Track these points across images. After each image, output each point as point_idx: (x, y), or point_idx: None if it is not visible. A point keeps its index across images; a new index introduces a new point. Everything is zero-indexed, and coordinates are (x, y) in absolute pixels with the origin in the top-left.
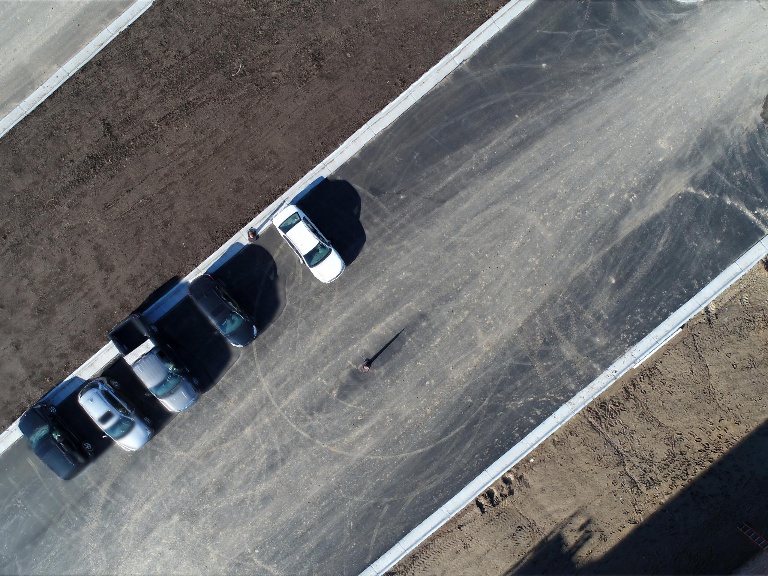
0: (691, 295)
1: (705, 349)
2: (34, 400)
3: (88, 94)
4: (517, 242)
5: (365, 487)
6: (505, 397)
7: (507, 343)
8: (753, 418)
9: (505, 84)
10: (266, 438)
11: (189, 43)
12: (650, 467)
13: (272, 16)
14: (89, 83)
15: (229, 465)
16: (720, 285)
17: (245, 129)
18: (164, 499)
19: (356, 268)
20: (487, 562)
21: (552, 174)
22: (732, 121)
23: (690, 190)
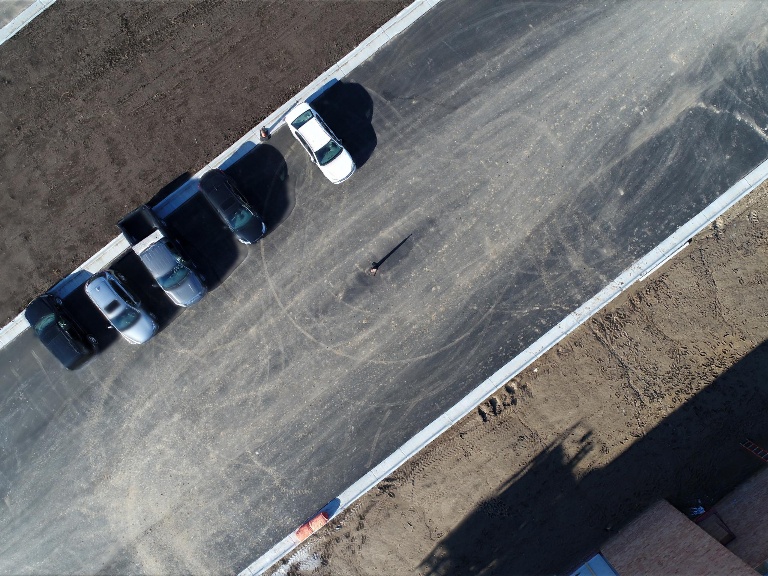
0: (699, 209)
1: (712, 264)
2: (41, 292)
3: None
4: (527, 151)
5: (368, 391)
6: (511, 305)
7: (514, 252)
8: (758, 334)
9: None
10: (270, 339)
11: None
12: (654, 380)
13: None
14: None
15: (233, 365)
16: (728, 200)
17: (261, 29)
18: (166, 397)
19: (366, 171)
20: (488, 471)
21: (564, 84)
22: (744, 38)
23: (701, 105)
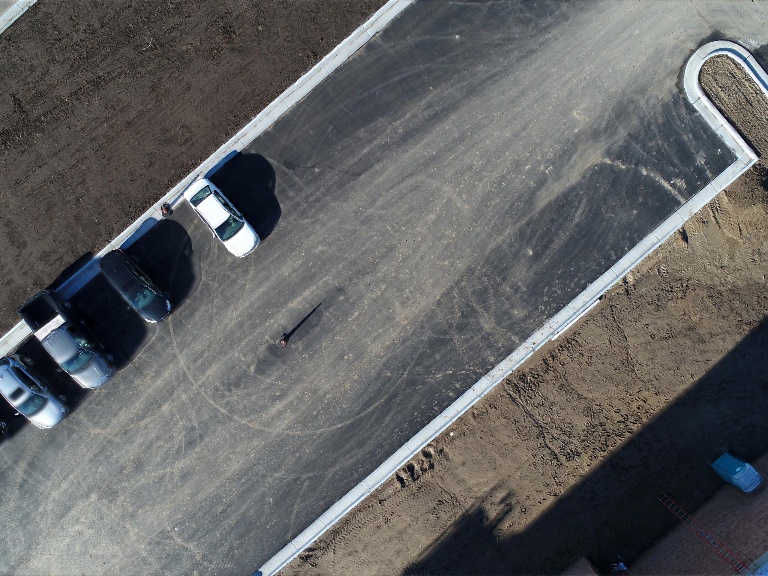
0: (608, 266)
1: (623, 320)
2: None
3: None
4: (433, 215)
5: (284, 463)
6: (424, 370)
7: (425, 316)
8: (671, 388)
9: (419, 56)
10: (184, 415)
11: (99, 17)
12: (569, 439)
13: None
14: None
15: (147, 442)
16: (637, 255)
17: (157, 103)
18: (82, 478)
19: (272, 242)
20: (408, 536)
21: (467, 146)
22: (647, 91)
23: (606, 161)
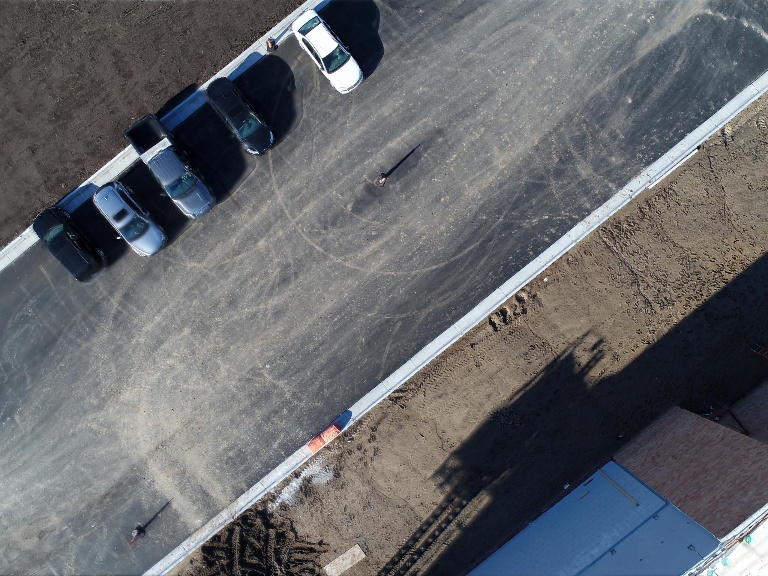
0: (707, 116)
1: (721, 170)
2: (48, 206)
3: None
4: (535, 60)
5: (378, 303)
6: (520, 215)
7: (523, 161)
8: None
9: None
10: (280, 251)
11: None
12: (664, 287)
13: None
14: None
15: (242, 278)
16: (736, 106)
17: None
18: (176, 311)
19: (374, 81)
20: (499, 380)
21: None
22: None
23: (708, 12)
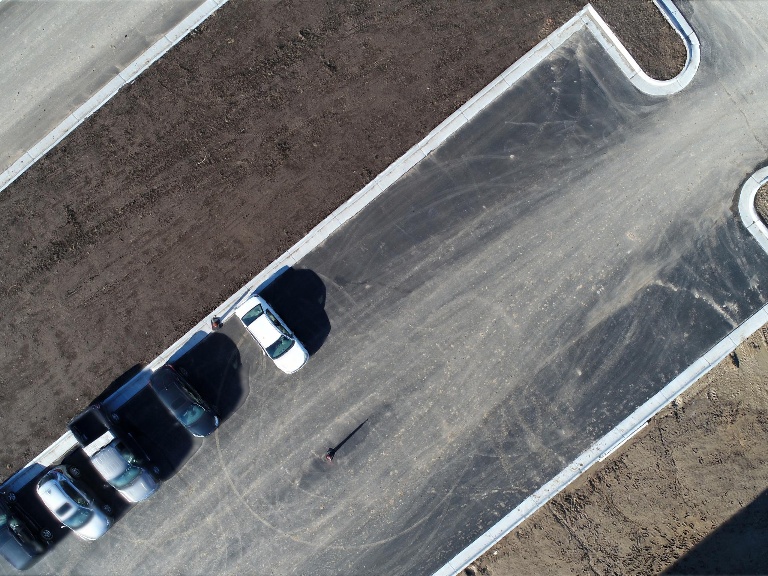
0: (658, 389)
1: (672, 443)
2: None
3: (53, 180)
4: (483, 333)
5: None
6: (469, 489)
7: (472, 434)
8: (719, 514)
9: (473, 175)
10: (227, 527)
11: (155, 131)
12: (615, 562)
13: (238, 105)
14: (54, 169)
15: (190, 553)
16: (687, 379)
17: (210, 218)
18: None
19: (320, 357)
20: None
21: (519, 265)
22: (701, 214)
23: (658, 283)
